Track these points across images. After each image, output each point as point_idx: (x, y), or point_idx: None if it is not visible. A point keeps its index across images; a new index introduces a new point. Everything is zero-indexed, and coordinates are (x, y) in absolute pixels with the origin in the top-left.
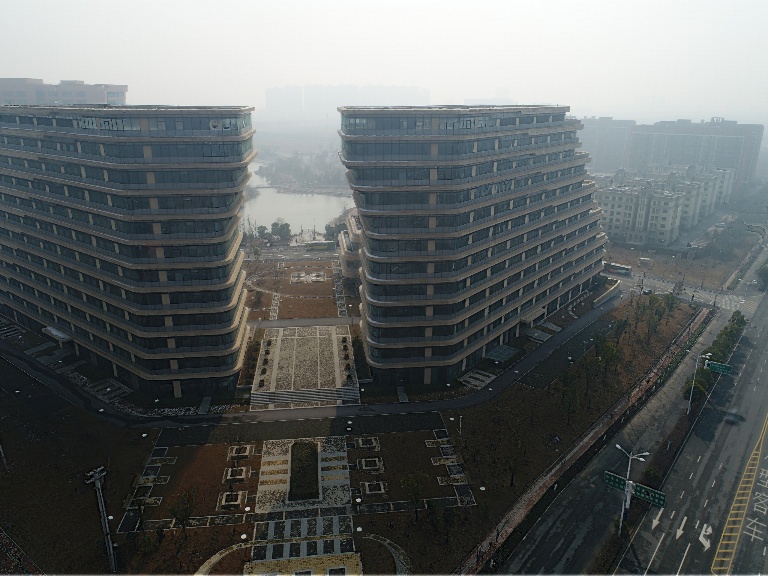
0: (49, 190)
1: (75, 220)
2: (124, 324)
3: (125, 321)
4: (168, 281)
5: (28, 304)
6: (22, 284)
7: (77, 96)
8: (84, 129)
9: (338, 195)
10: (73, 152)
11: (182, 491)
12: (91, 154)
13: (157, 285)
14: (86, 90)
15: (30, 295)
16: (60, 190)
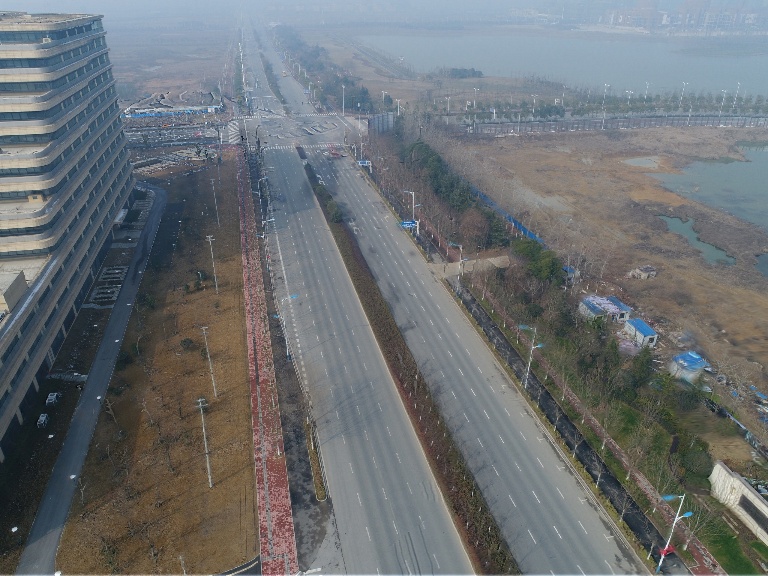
0: None
1: None
2: (126, 157)
3: None
4: None
5: None
6: None
7: None
8: None
9: None
10: None
11: (183, 169)
12: None
13: None
14: None
15: None
16: None
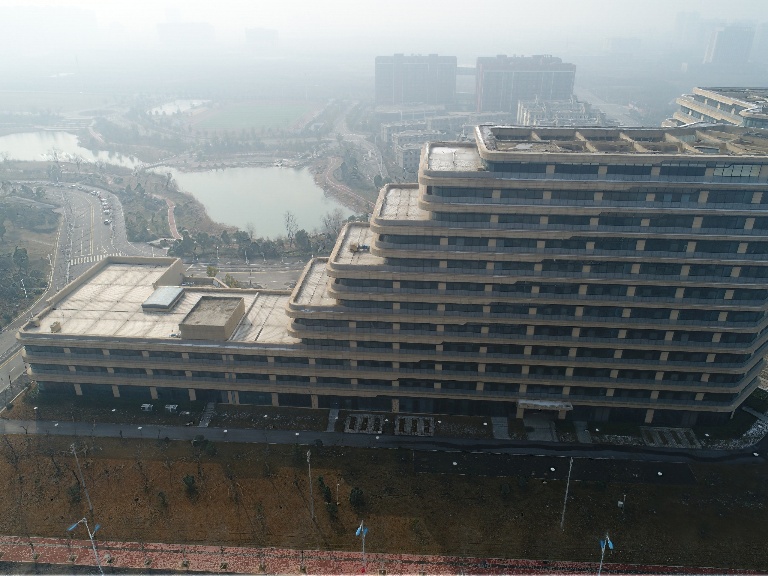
0: (594, 247)
1: (648, 275)
2: (705, 367)
3: (706, 364)
4: (767, 313)
5: (448, 385)
6: (445, 364)
7: None
8: (731, 177)
9: (260, 165)
10: (688, 202)
11: None
12: (730, 203)
13: (762, 320)
14: None
15: (462, 373)
16: (625, 245)
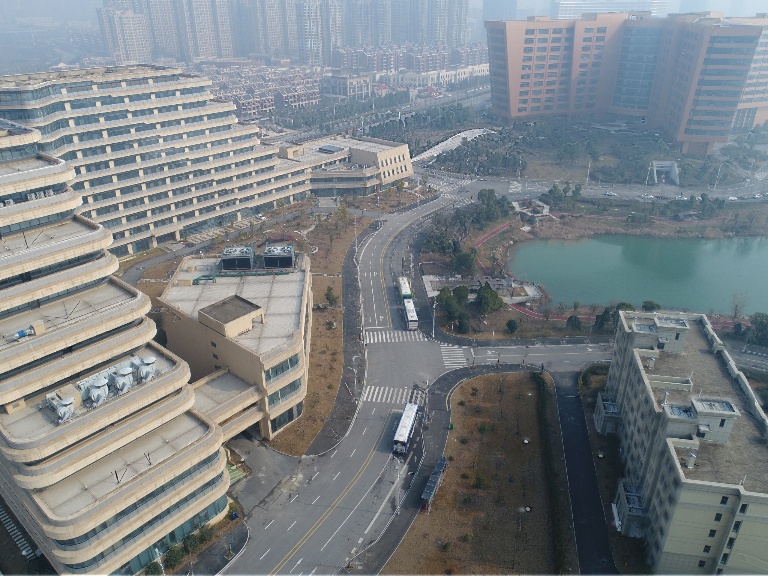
0: None
1: None
2: None
3: None
4: None
5: None
6: None
7: (695, 39)
8: None
9: None
10: None
11: None
12: None
13: None
14: (700, 32)
15: None
16: None
